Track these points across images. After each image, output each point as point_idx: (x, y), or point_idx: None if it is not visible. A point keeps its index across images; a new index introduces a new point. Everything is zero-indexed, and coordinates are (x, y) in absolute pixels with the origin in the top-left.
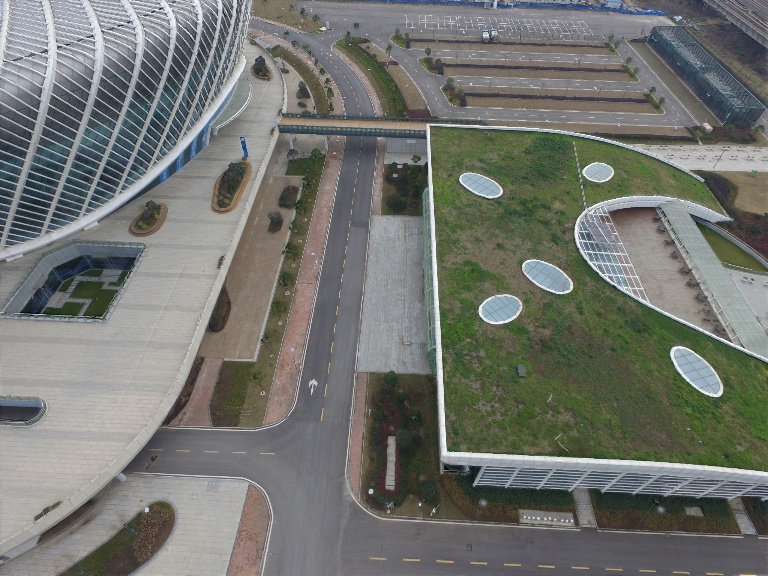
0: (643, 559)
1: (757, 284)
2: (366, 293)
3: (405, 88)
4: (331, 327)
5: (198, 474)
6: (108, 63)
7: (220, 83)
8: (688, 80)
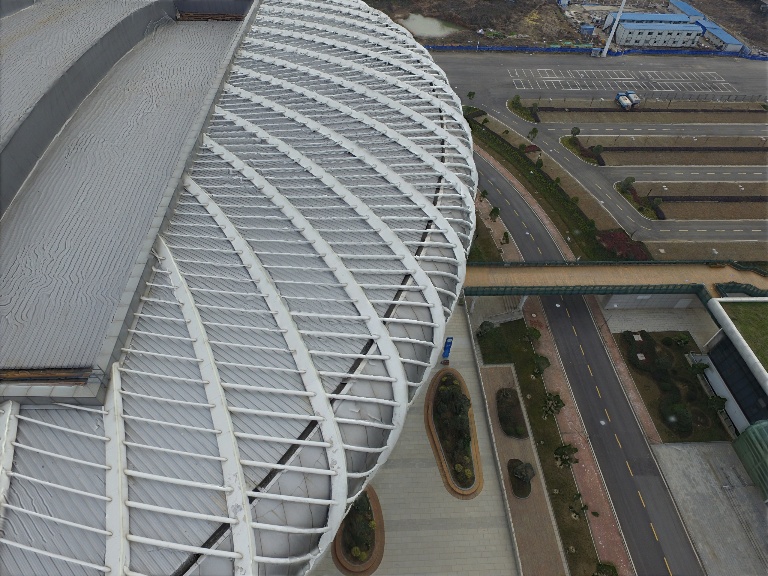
0: None
1: None
2: None
3: (571, 191)
4: None
5: None
6: (408, 396)
7: None
8: None
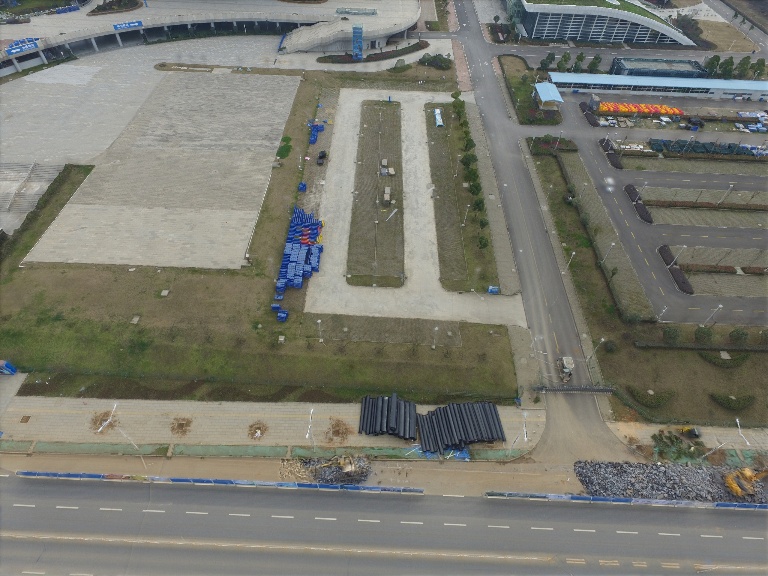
0: (591, 51)
1: None
2: (476, 9)
3: None
4: (465, 15)
5: None
6: None
7: None
8: None
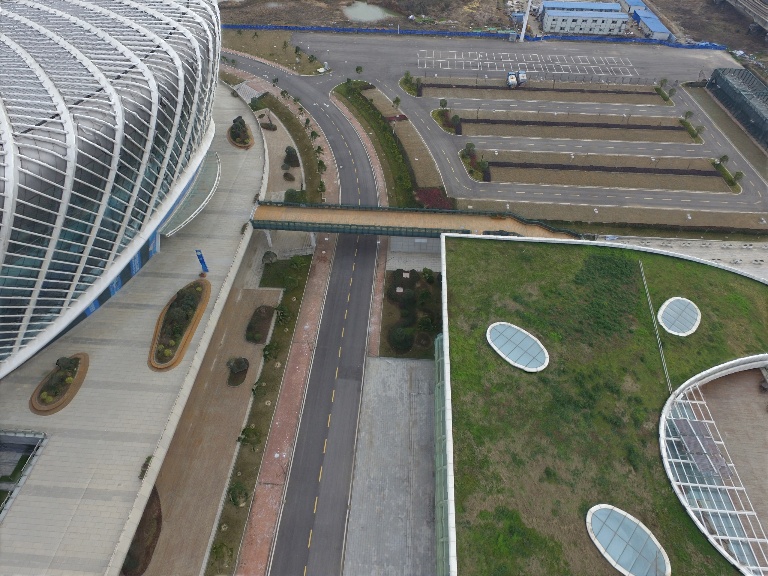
0: None
1: None
2: (353, 504)
3: (415, 154)
4: (299, 573)
5: None
6: None
7: (168, 183)
8: (764, 141)
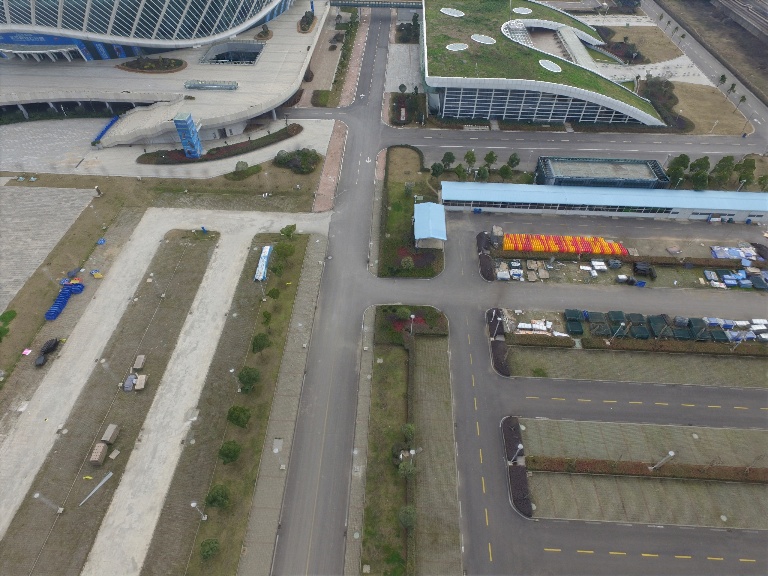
0: (519, 137)
1: (610, 67)
2: (388, 70)
3: None
4: (370, 80)
5: (310, 119)
6: None
7: None
8: None
